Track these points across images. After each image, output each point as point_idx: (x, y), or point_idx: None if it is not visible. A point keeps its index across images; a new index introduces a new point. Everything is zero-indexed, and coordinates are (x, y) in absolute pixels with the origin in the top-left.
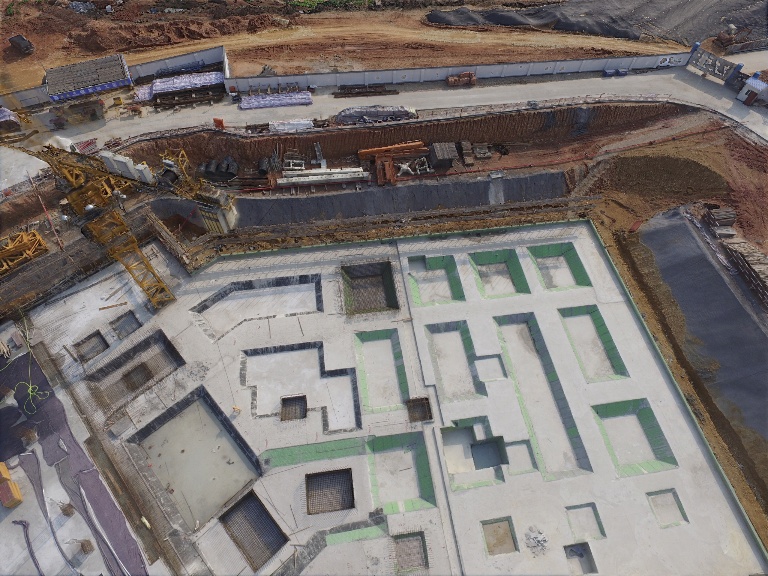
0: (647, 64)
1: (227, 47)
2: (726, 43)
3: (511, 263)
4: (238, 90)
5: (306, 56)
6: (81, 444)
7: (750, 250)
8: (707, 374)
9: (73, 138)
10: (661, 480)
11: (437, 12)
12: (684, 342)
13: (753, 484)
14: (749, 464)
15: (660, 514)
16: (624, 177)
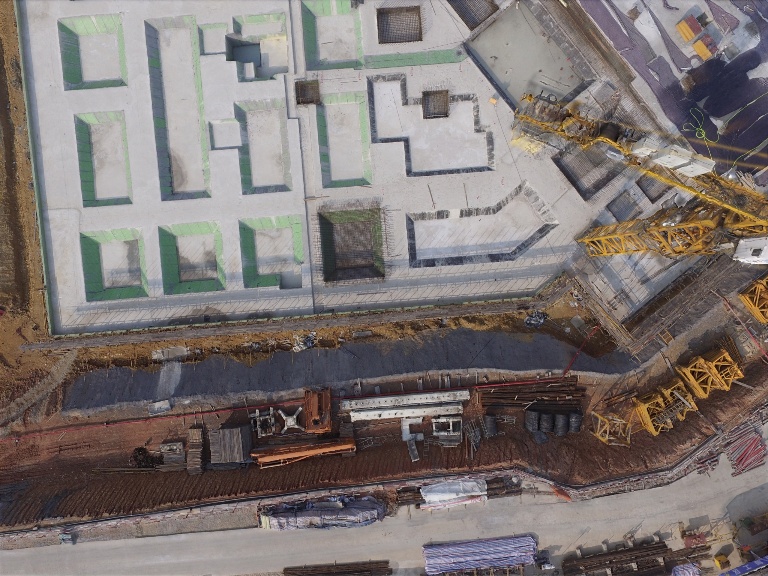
0: None
1: None
2: None
3: (174, 277)
4: None
5: None
6: (638, 75)
7: None
8: None
9: (766, 479)
10: (80, 9)
11: None
12: None
13: None
14: None
15: None
16: None
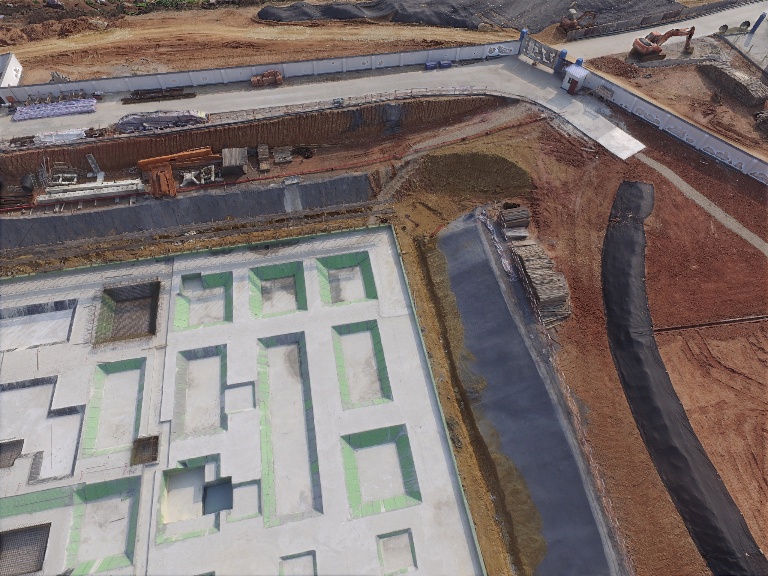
0: (475, 54)
1: (28, 54)
2: (569, 29)
3: (298, 277)
4: (18, 100)
5: (110, 60)
6: None
7: (533, 253)
8: (474, 394)
9: None
10: (397, 519)
11: (267, 8)
12: (459, 358)
13: (502, 518)
14: (501, 495)
15: (388, 559)
16: (434, 177)
